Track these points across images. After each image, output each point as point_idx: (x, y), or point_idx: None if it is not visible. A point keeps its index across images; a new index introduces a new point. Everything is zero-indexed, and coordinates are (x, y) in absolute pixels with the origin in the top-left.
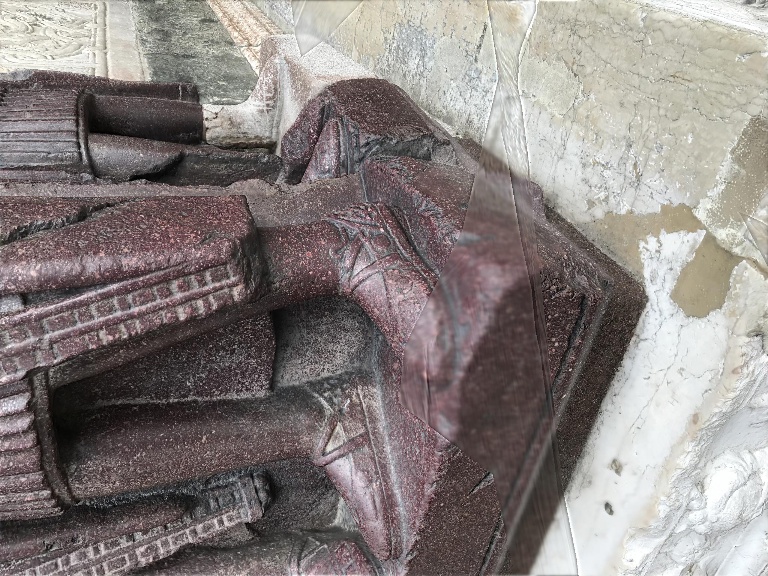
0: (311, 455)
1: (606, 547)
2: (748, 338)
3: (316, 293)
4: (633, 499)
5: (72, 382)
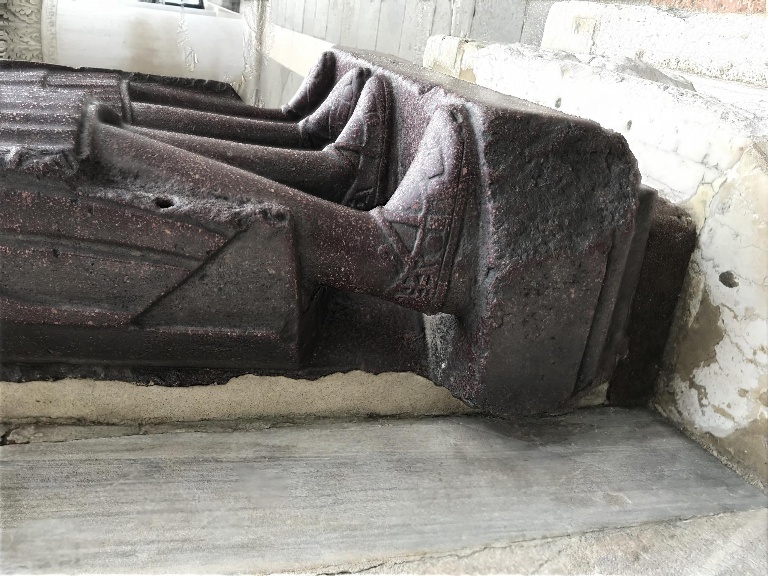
0: (298, 125)
1: (581, 95)
2: (479, 49)
3: (269, 110)
4: (547, 84)
5: (140, 93)
